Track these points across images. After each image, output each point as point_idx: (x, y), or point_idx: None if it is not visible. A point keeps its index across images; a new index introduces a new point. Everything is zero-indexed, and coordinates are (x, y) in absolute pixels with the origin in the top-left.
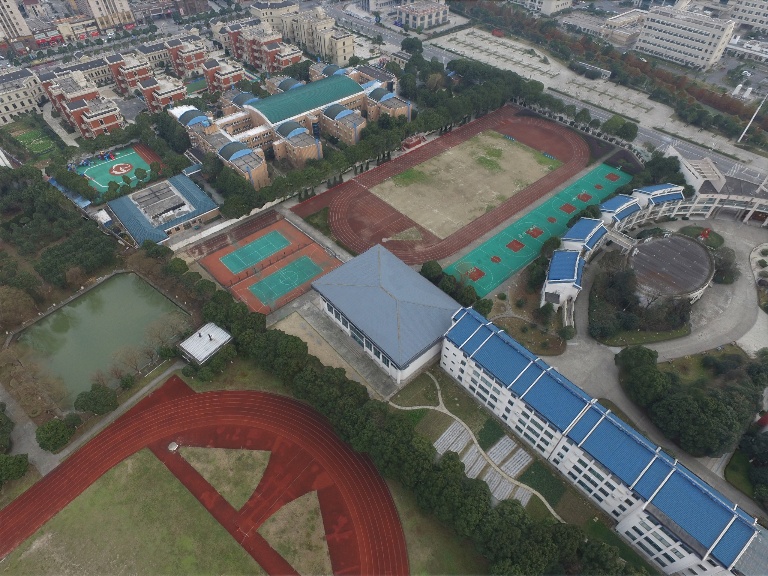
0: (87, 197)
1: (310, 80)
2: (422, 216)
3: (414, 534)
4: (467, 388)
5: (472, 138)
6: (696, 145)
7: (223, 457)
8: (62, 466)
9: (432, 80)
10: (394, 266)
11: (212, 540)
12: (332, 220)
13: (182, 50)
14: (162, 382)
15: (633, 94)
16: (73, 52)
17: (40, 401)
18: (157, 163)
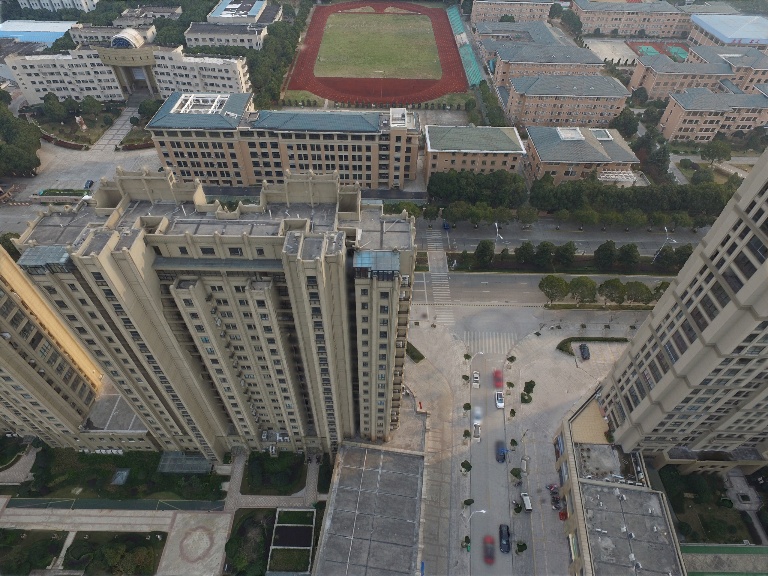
0: None
1: None
2: None
3: (422, 4)
4: None
5: None
6: None
7: None
8: None
9: None
10: None
11: None
12: None
13: None
14: None
15: None
16: None
17: None
18: None
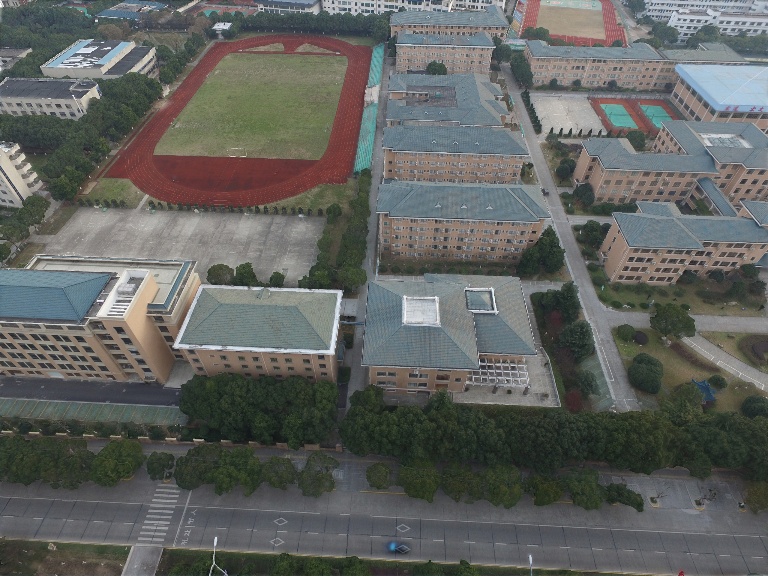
0: None
1: None
2: None
3: (347, 40)
4: None
5: None
6: None
7: (264, 47)
8: None
9: None
10: None
11: (281, 56)
12: None
13: None
14: None
15: None
16: None
17: None
18: None
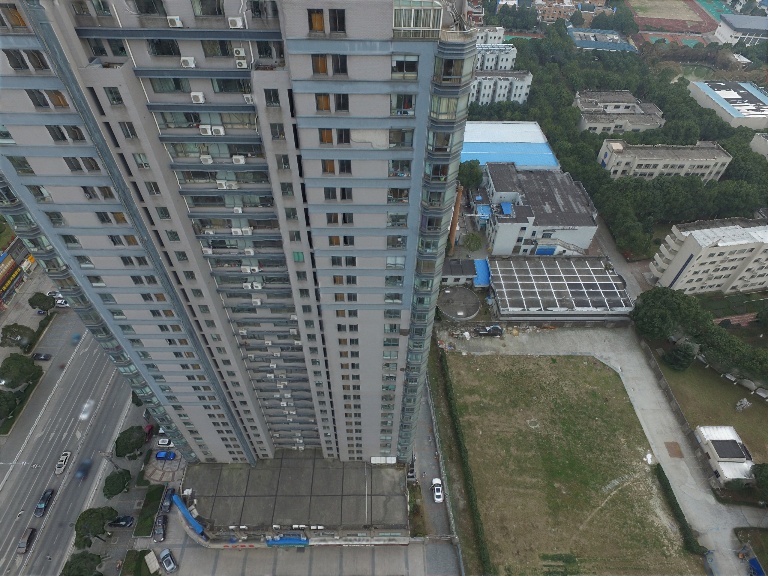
0: None
1: None
2: (679, 17)
3: None
4: None
5: None
6: None
7: None
8: None
9: None
10: None
11: None
12: None
13: None
14: None
15: None
16: None
17: (767, 72)
18: None
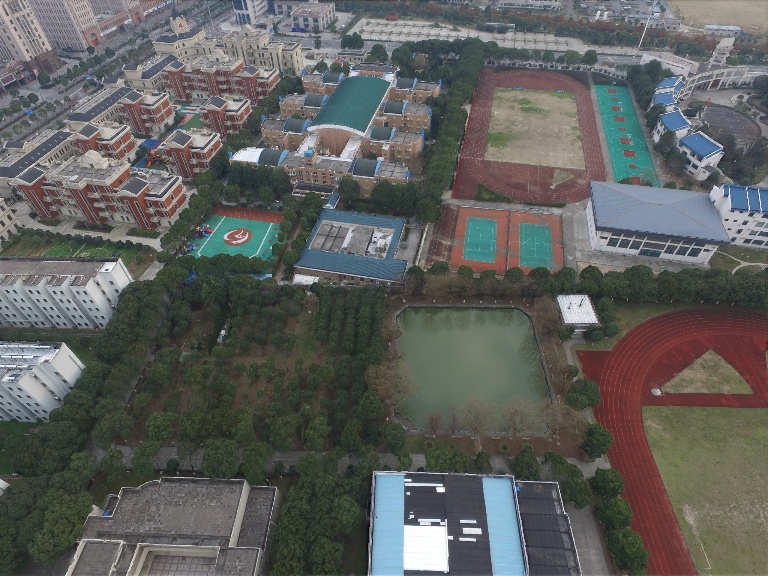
0: (264, 271)
1: None
2: (550, 161)
3: None
4: (740, 244)
5: (494, 97)
6: (622, 56)
7: (694, 373)
8: (614, 463)
9: (421, 61)
10: (626, 188)
11: None
12: (496, 191)
13: (147, 102)
14: (577, 361)
15: (543, 36)
16: None
17: None
18: (291, 210)
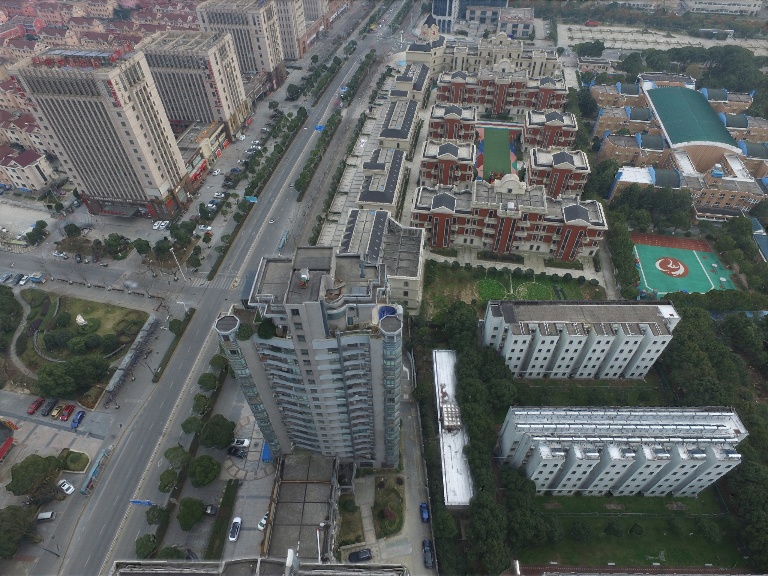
0: None
1: (597, 106)
2: None
3: None
4: None
5: None
6: None
7: None
8: None
9: None
10: None
11: None
12: None
13: (468, 117)
14: None
15: (767, 43)
16: (265, 174)
17: None
18: (730, 237)
